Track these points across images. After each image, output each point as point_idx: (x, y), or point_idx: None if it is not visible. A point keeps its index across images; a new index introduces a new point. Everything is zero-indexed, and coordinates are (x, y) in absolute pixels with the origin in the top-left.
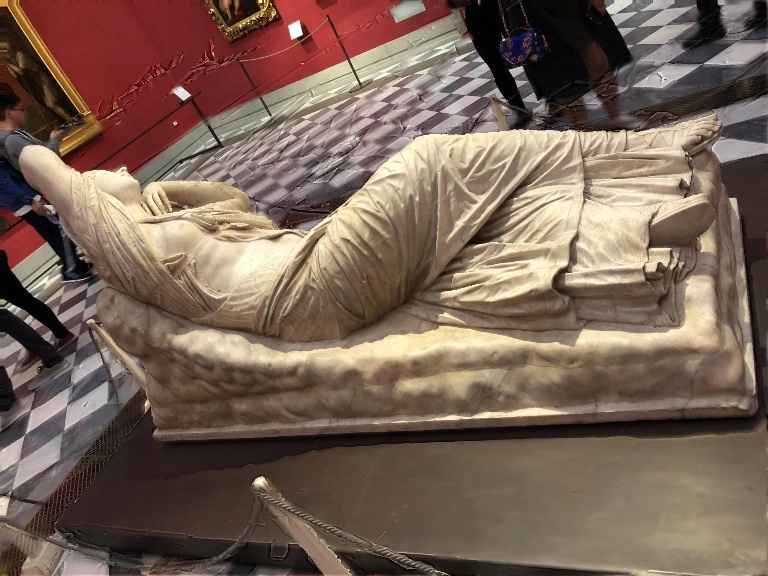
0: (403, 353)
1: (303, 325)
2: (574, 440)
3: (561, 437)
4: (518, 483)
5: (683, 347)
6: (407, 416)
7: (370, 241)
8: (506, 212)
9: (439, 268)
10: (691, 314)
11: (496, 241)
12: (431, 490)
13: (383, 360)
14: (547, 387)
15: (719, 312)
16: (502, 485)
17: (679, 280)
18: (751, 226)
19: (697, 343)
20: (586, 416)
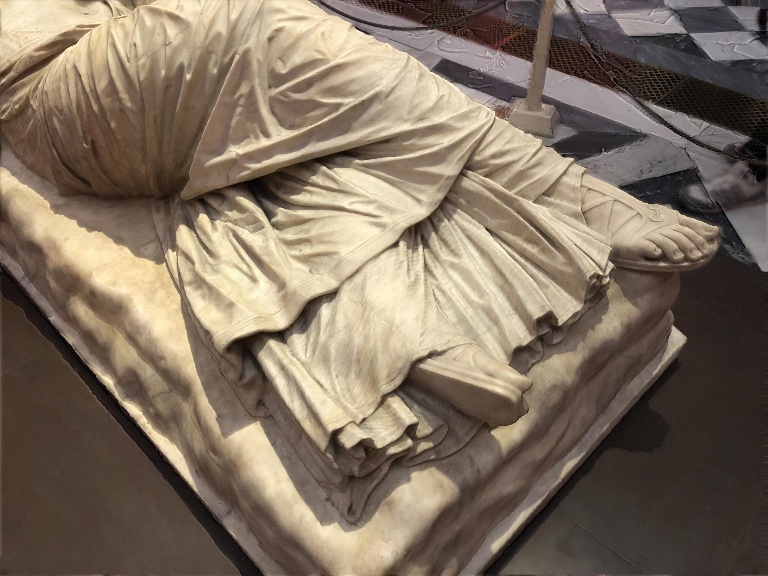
0: (91, 270)
1: (23, 146)
2: (194, 522)
3: (187, 505)
4: (93, 525)
5: (322, 564)
6: (80, 339)
7: (105, 96)
8: (304, 178)
9: (191, 191)
10: (376, 525)
11: (272, 208)
12: (23, 451)
13: (65, 261)
14: (190, 448)
15: (418, 548)
16: (77, 513)
17: (405, 464)
18: (670, 388)
19: (341, 575)
20: (213, 513)
